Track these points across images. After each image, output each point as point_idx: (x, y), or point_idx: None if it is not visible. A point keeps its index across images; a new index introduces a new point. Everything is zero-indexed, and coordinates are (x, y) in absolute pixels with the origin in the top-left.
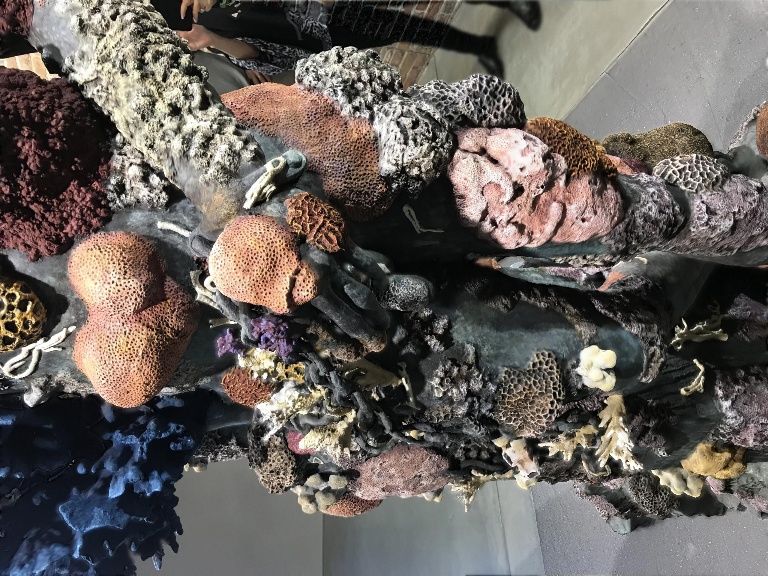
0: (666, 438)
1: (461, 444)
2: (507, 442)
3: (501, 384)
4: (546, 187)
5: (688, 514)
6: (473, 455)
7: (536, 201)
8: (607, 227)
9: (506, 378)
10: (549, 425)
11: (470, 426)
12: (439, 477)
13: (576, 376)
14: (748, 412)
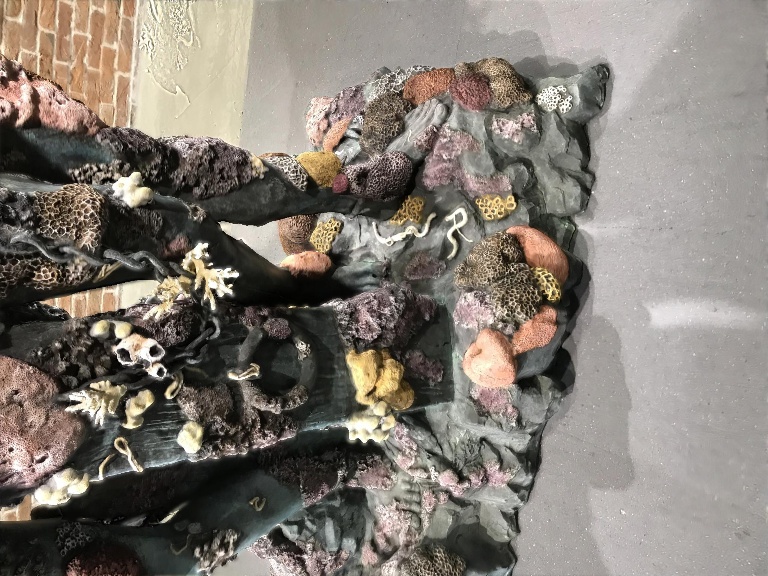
0: (288, 321)
1: (55, 344)
2: (106, 323)
3: (34, 197)
4: (10, 77)
5: (482, 571)
6: (85, 372)
7: (6, 85)
8: (89, 118)
9: (38, 194)
10: (102, 220)
11: (14, 231)
12: (53, 411)
13: (117, 200)
14: (351, 301)
